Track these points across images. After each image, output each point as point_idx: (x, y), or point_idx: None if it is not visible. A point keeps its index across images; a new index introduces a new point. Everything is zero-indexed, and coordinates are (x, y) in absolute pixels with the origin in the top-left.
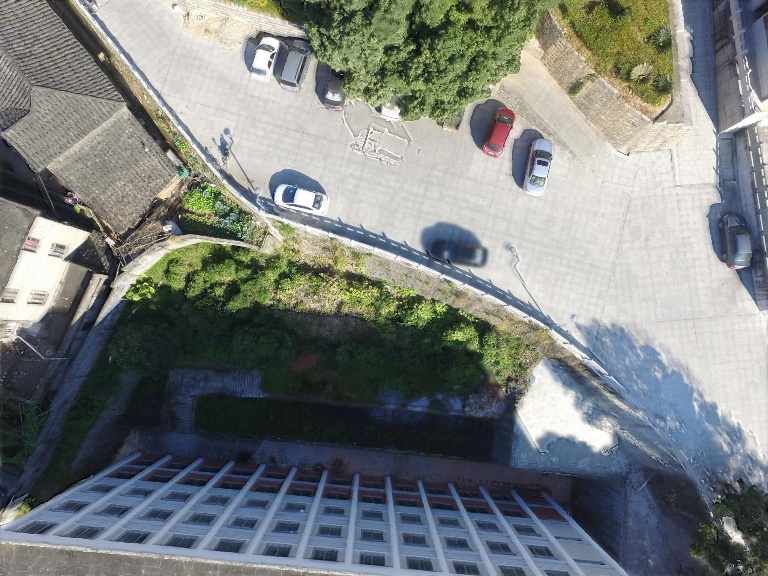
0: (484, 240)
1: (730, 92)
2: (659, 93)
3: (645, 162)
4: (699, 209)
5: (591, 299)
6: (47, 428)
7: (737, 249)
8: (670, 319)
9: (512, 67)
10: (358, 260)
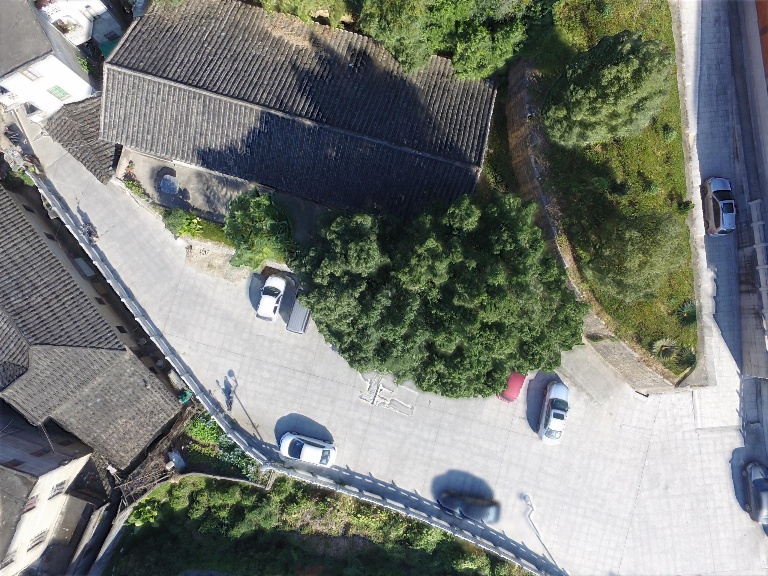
0: (497, 488)
1: (756, 342)
2: (683, 366)
3: (665, 404)
4: (721, 454)
5: (608, 551)
6: None
7: (761, 507)
8: (690, 573)
9: None
10: None
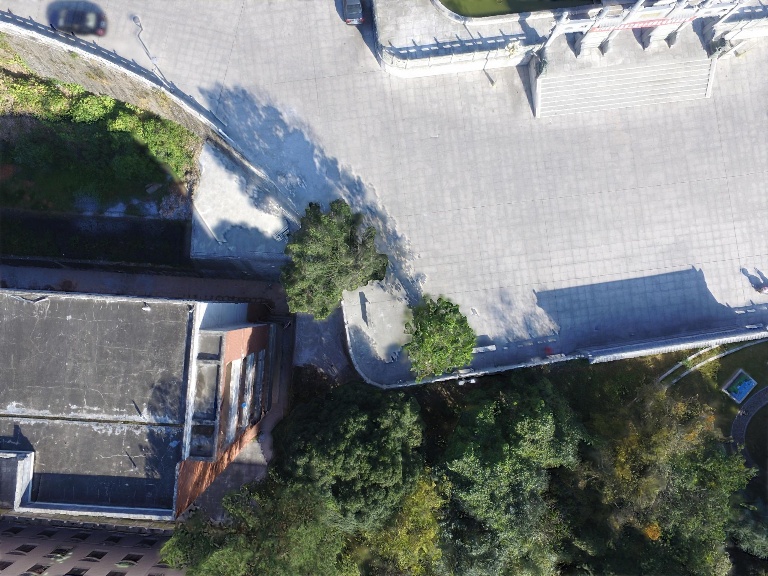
0: (108, 11)
1: None
2: None
3: None
4: None
5: (214, 64)
6: None
7: (346, 1)
8: (292, 80)
9: None
10: (5, 48)
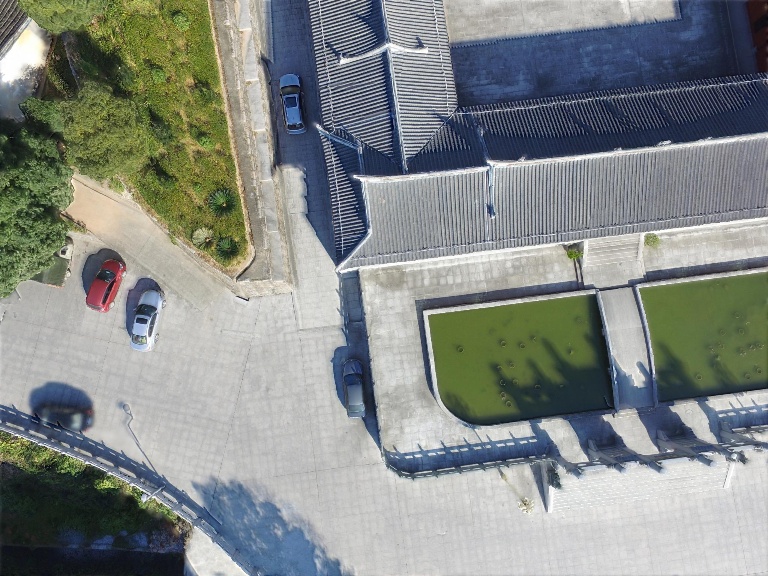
0: (96, 399)
1: None
2: (224, 257)
3: (265, 307)
4: (323, 354)
5: (208, 456)
6: None
7: (348, 401)
8: (291, 472)
9: (46, 247)
10: None
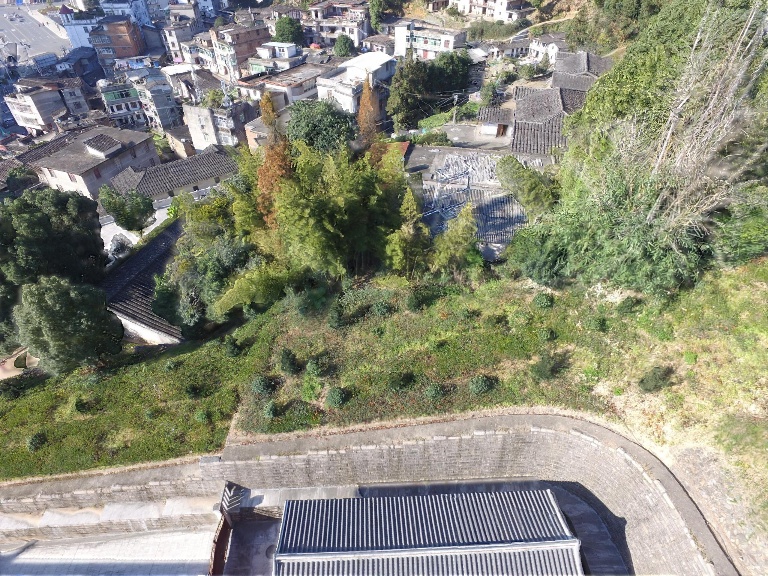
0: None
1: None
2: None
3: None
4: None
5: None
6: (1, 201)
7: None
8: None
9: None
10: None
